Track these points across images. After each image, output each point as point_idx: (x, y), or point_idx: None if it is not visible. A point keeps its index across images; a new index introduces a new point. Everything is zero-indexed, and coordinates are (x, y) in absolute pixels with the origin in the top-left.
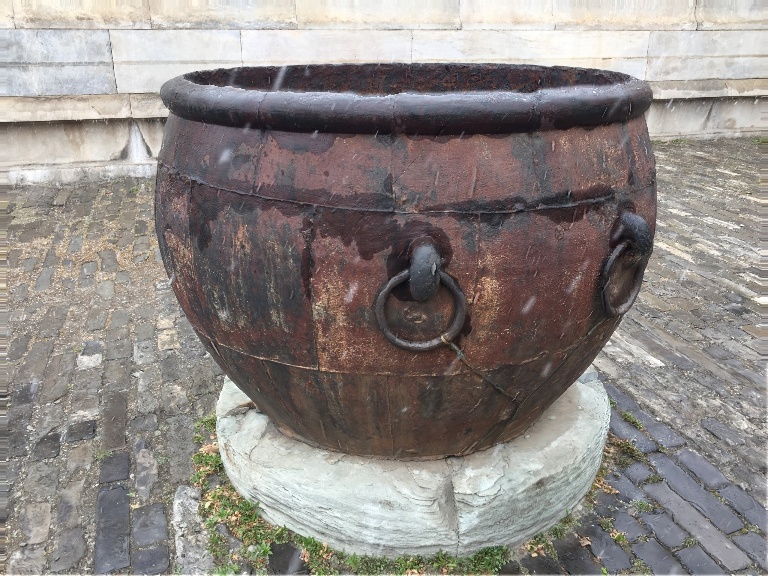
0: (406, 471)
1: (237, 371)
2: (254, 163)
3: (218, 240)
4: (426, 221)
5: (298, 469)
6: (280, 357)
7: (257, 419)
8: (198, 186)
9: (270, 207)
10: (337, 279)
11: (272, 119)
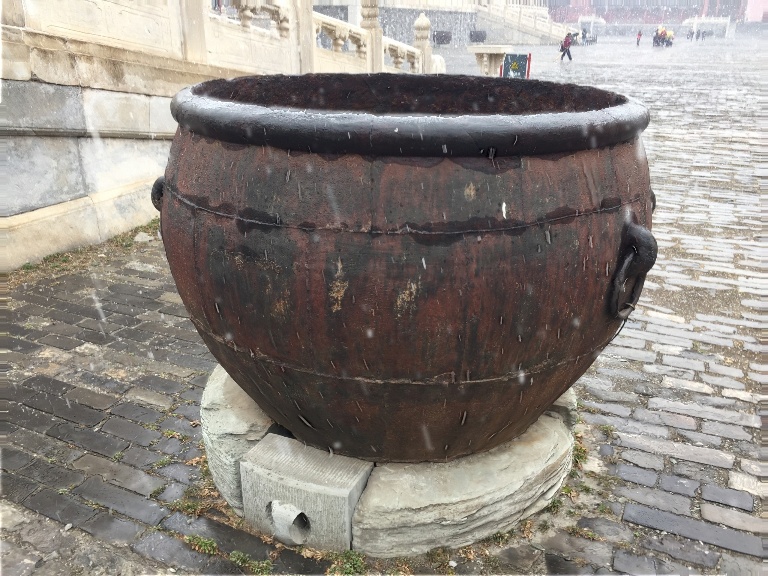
0: None
1: None
2: None
3: None
4: None
5: None
6: None
7: None
8: None
9: None
10: None
11: None
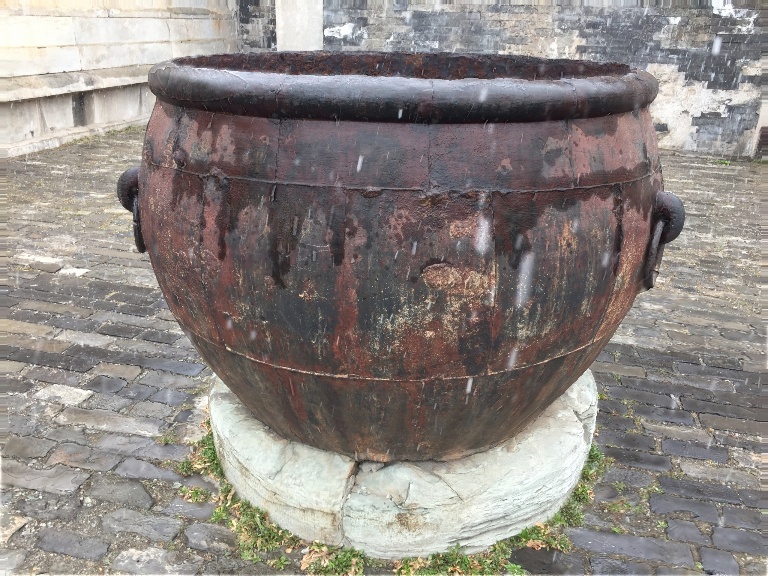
0: (555, 419)
1: (486, 399)
2: (568, 155)
3: (541, 248)
4: (656, 178)
5: (509, 472)
6: (565, 349)
7: (396, 472)
8: (503, 196)
9: (590, 196)
10: (633, 246)
11: (586, 107)
